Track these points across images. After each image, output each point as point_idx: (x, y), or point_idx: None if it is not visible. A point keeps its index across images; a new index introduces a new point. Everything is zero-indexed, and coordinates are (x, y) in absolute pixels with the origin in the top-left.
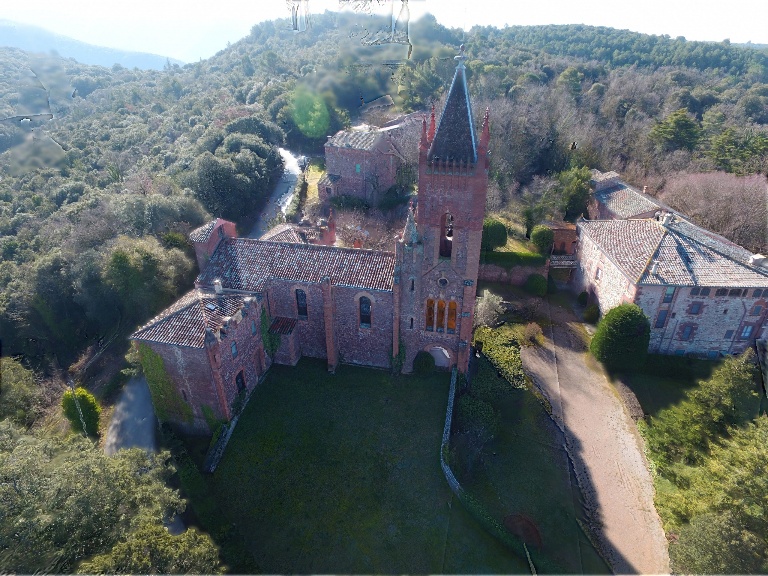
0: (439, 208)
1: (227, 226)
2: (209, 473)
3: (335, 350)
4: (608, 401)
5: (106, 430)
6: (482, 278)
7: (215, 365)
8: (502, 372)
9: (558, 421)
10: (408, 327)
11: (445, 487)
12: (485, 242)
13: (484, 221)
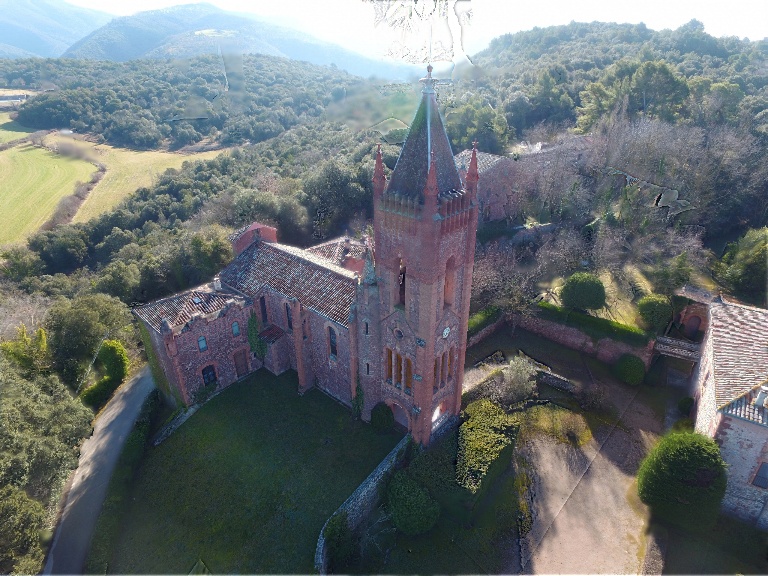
0: (392, 250)
1: (265, 230)
2: (153, 446)
3: (308, 372)
4: (620, 556)
5: (128, 380)
6: (561, 341)
7: (169, 353)
8: (460, 460)
9: (526, 550)
10: (364, 372)
11: (312, 559)
12: (570, 299)
13: (576, 274)
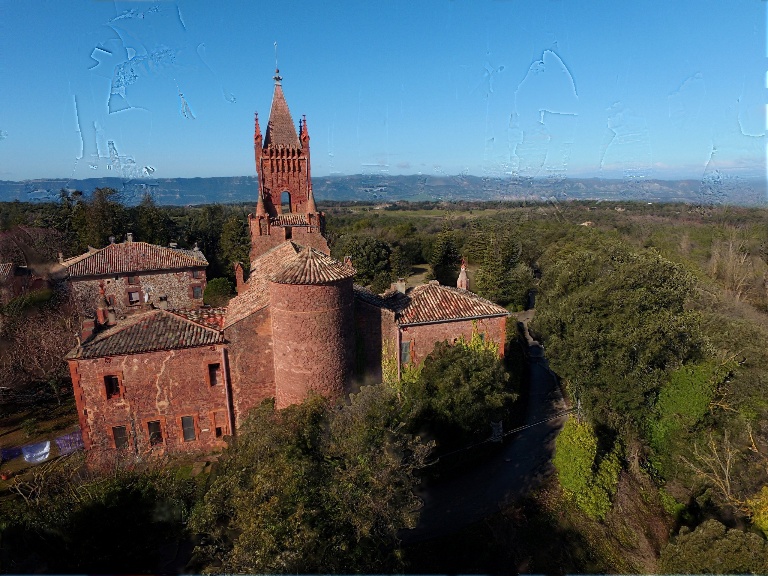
0: None
1: None
2: None
3: None
4: None
5: (554, 474)
6: None
7: None
8: None
9: None
10: None
11: None
12: None
13: None
